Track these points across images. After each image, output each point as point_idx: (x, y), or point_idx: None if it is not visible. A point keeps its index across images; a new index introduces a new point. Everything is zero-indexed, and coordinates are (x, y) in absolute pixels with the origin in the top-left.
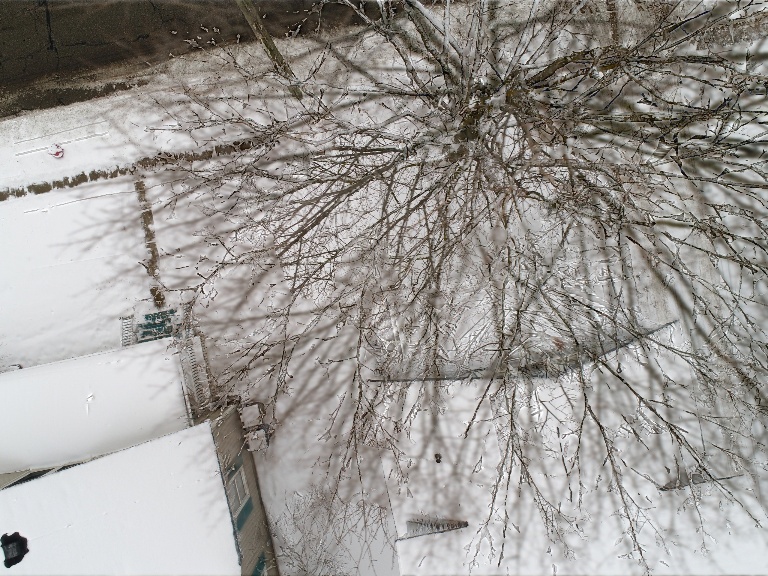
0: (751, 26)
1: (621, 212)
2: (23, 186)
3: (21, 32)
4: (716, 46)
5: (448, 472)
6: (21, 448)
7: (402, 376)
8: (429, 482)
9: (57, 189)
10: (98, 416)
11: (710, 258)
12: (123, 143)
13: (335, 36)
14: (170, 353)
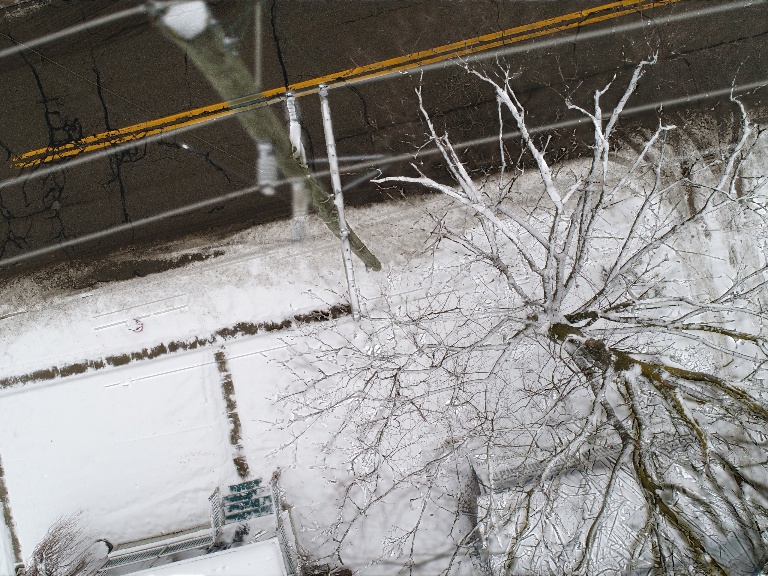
0: None
1: None
2: (101, 358)
3: (95, 206)
4: None
5: None
6: None
7: None
8: None
9: (136, 361)
10: None
11: None
12: (202, 316)
13: None
14: (275, 557)
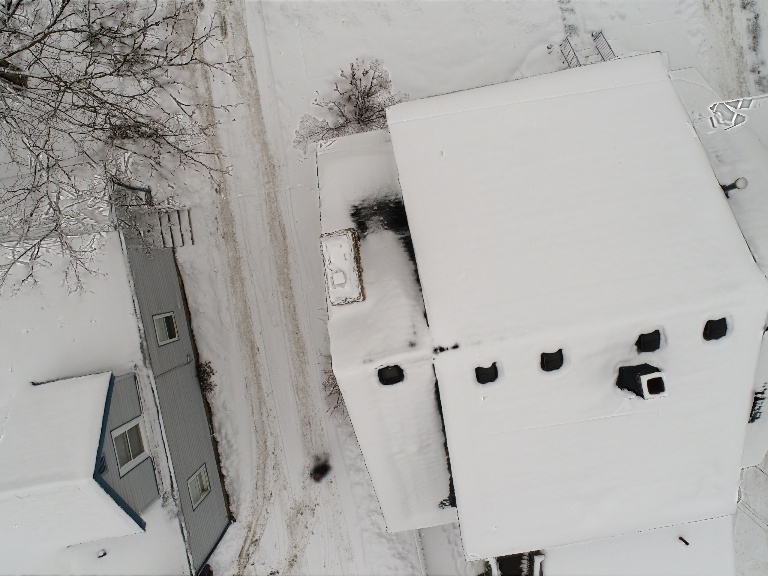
0: None
1: None
2: None
3: None
4: None
5: None
6: None
7: None
8: None
9: None
10: None
11: None
12: None
13: None
14: None
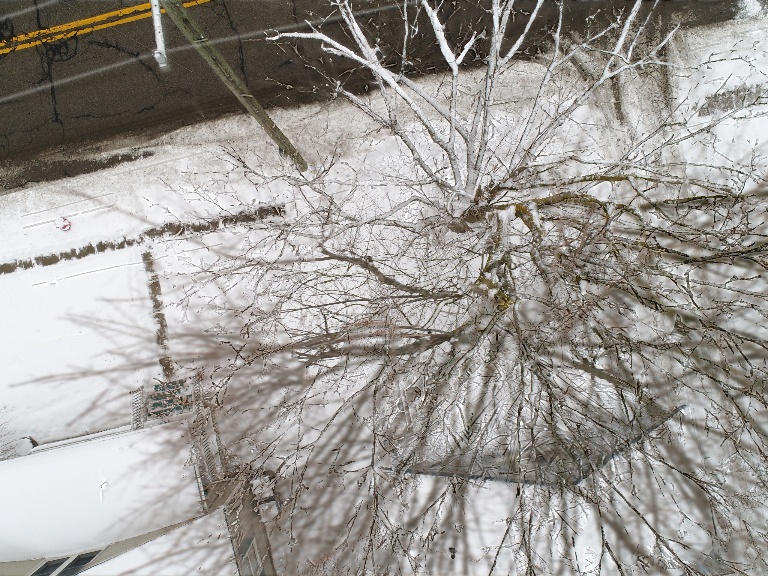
0: (752, 92)
1: (639, 393)
2: (31, 258)
3: (26, 105)
4: (718, 112)
5: (463, 567)
6: (36, 537)
7: (415, 466)
8: (444, 574)
9: (65, 261)
10: (112, 503)
11: (723, 388)
12: (130, 215)
13: (339, 106)
14: None
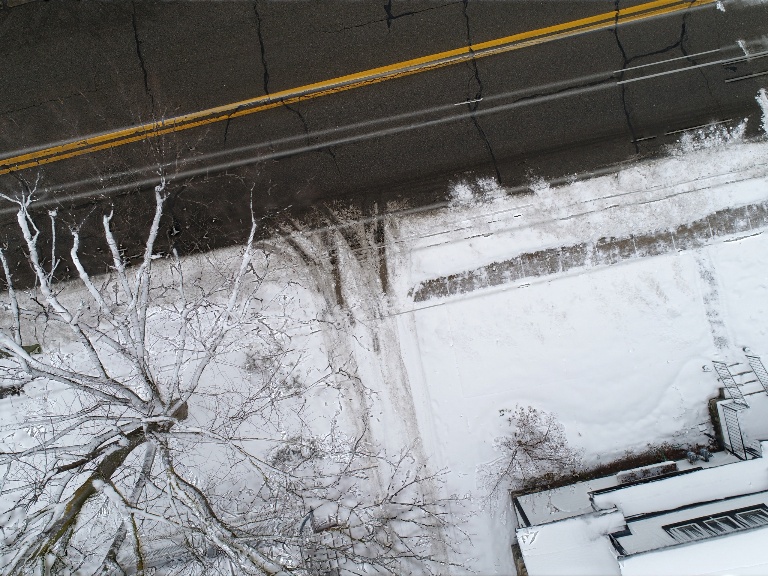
0: (465, 278)
1: None
2: None
3: None
4: (432, 298)
5: None
6: None
7: None
8: None
9: None
10: None
11: None
12: None
13: (74, 288)
14: None
